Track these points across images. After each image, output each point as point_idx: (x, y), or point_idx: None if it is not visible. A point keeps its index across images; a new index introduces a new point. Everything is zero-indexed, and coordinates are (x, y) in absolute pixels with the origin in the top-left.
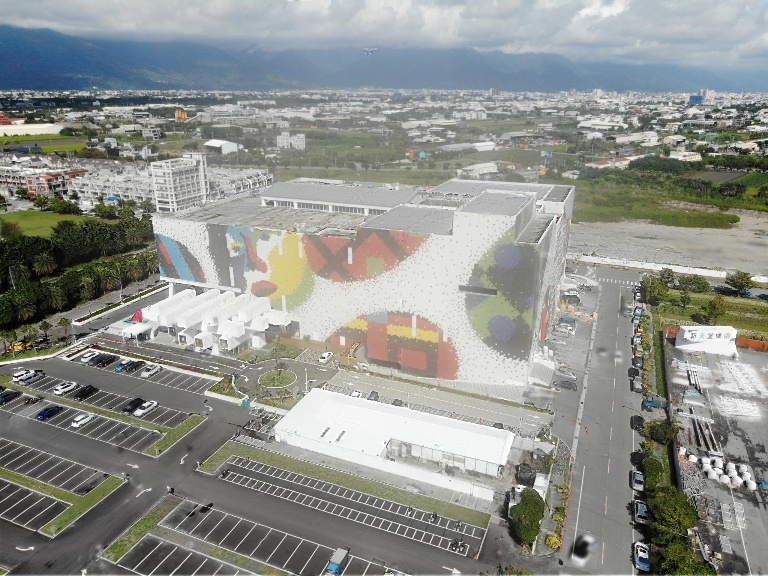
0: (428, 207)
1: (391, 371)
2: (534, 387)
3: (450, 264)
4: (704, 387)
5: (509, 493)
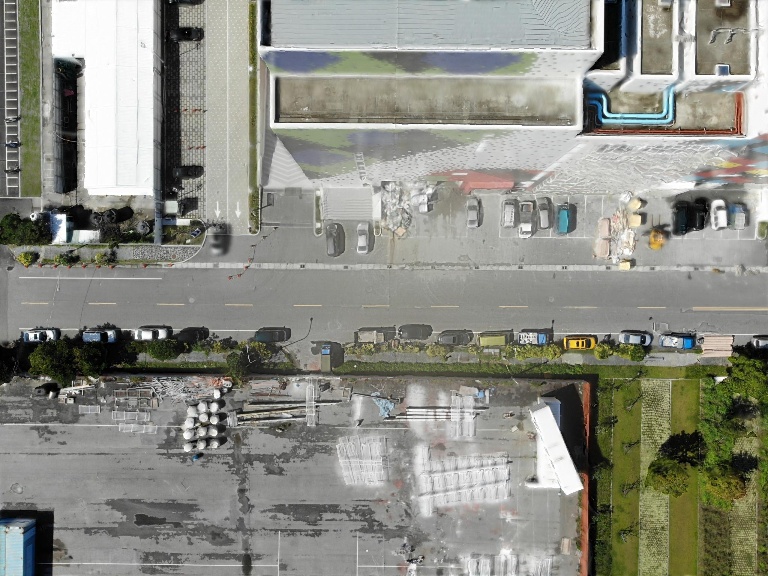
0: None
1: None
2: (314, 199)
3: None
4: (411, 425)
5: (54, 208)
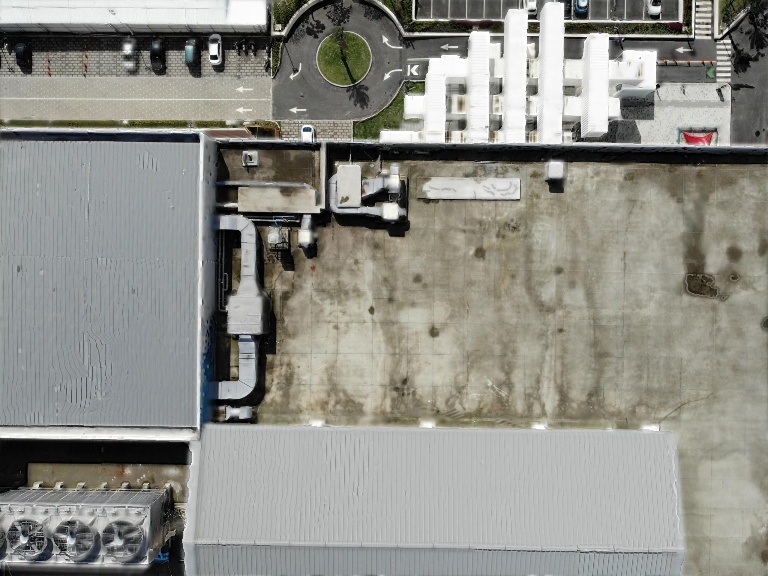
0: (128, 432)
1: None
2: None
3: None
4: None
5: None
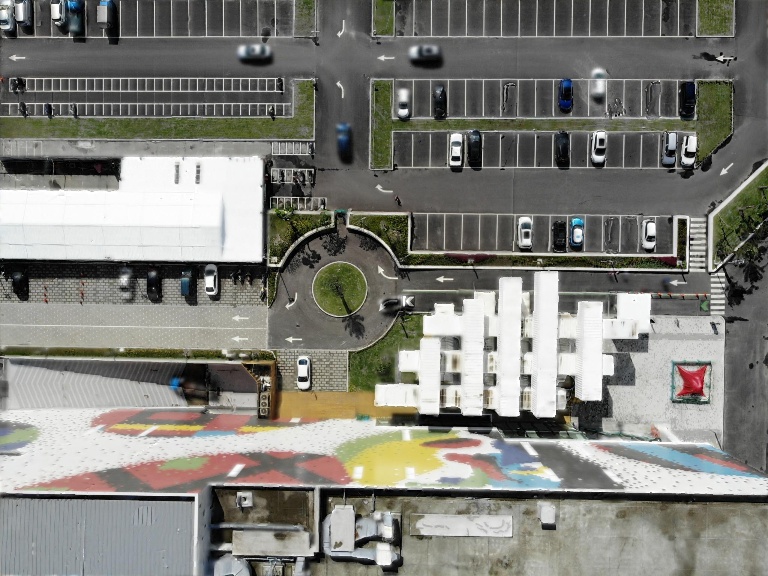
0: None
1: (188, 360)
2: None
3: (13, 468)
4: None
5: None
